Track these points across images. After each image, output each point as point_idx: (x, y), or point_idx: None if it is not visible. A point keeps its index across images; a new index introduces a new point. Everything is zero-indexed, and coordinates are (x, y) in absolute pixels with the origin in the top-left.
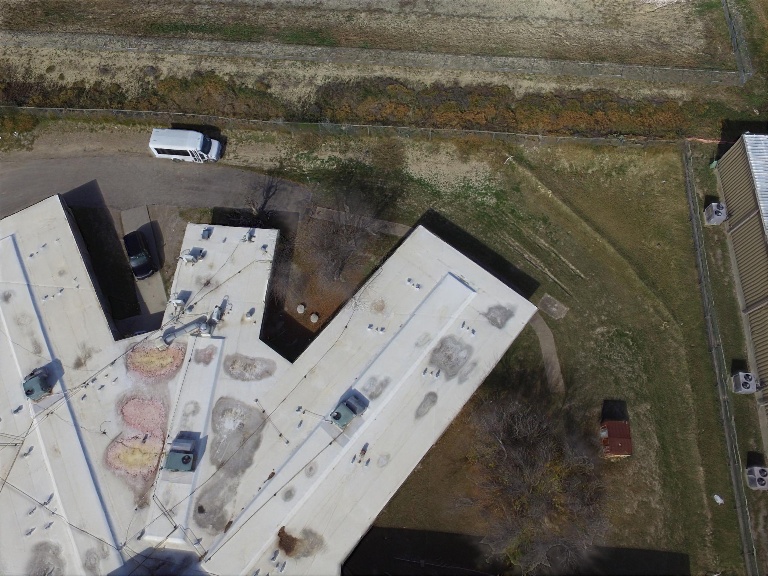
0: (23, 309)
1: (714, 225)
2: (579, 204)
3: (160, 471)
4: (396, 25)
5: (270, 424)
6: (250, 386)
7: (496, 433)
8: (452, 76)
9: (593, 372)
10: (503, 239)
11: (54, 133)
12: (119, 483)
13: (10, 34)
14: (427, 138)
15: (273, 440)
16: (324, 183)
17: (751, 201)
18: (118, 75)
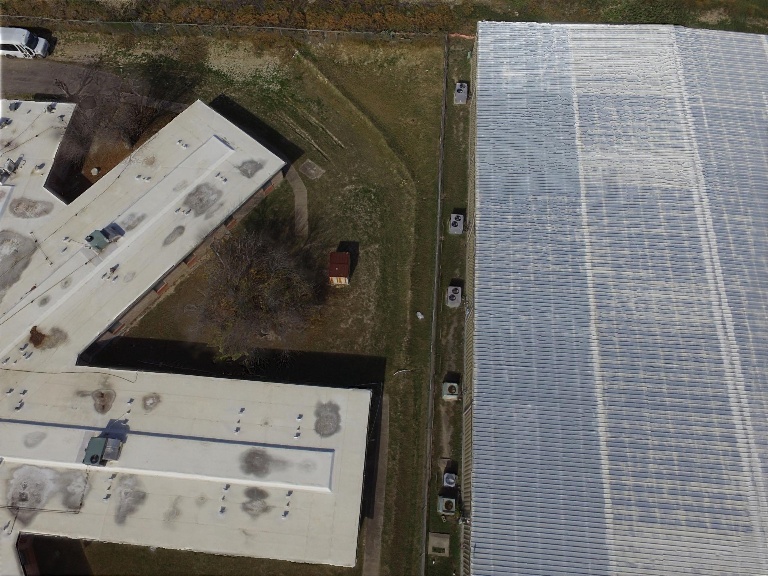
0: None
1: (461, 104)
2: (351, 89)
3: None
4: None
5: (39, 250)
6: (28, 222)
7: (214, 247)
8: None
9: (336, 220)
10: (280, 117)
11: None
12: None
13: None
14: (227, 36)
15: (40, 262)
16: (134, 74)
17: None
18: None
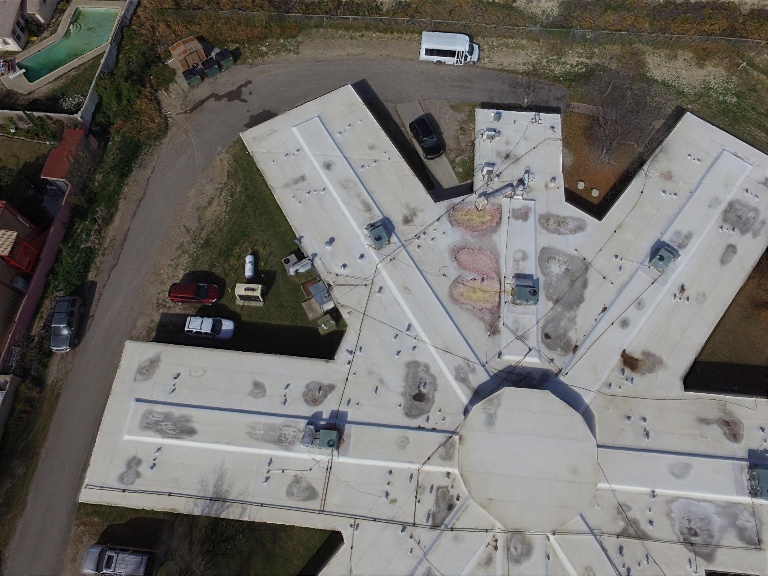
0: (345, 176)
1: None
2: None
3: (505, 305)
4: None
5: (593, 269)
6: (567, 239)
7: None
8: None
9: None
10: (750, 131)
11: (317, 40)
12: (468, 315)
13: None
14: (667, 46)
15: (598, 282)
16: (577, 83)
17: None
18: None
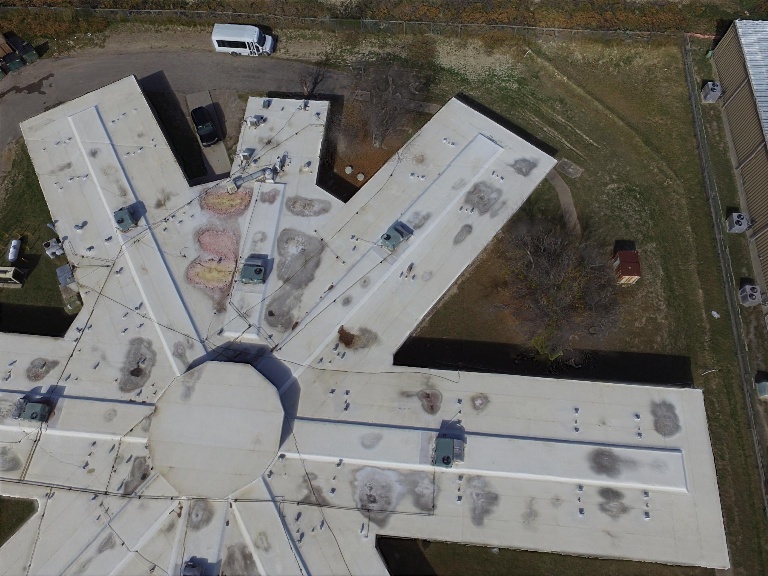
0: (108, 162)
1: (710, 103)
2: (591, 88)
3: (235, 284)
4: None
5: (328, 249)
6: (309, 220)
7: (525, 245)
8: None
9: (605, 219)
10: (525, 116)
11: (123, 34)
12: (199, 294)
13: None
14: (456, 35)
15: (331, 261)
16: None
17: (742, 73)
18: None
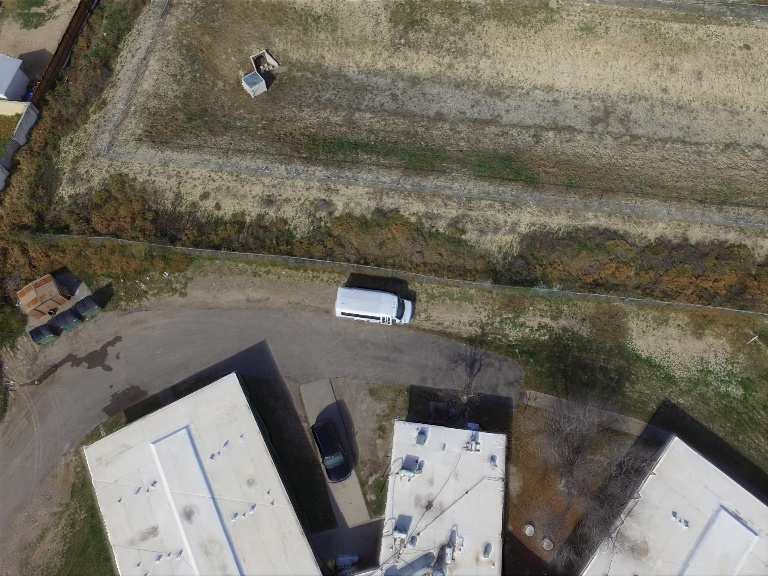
0: (210, 533)
1: None
2: None
3: None
4: (594, 151)
5: None
6: None
7: None
8: (680, 230)
9: None
10: (759, 445)
11: (211, 275)
12: None
13: (154, 148)
14: (656, 308)
15: None
16: (537, 359)
17: None
18: (284, 208)
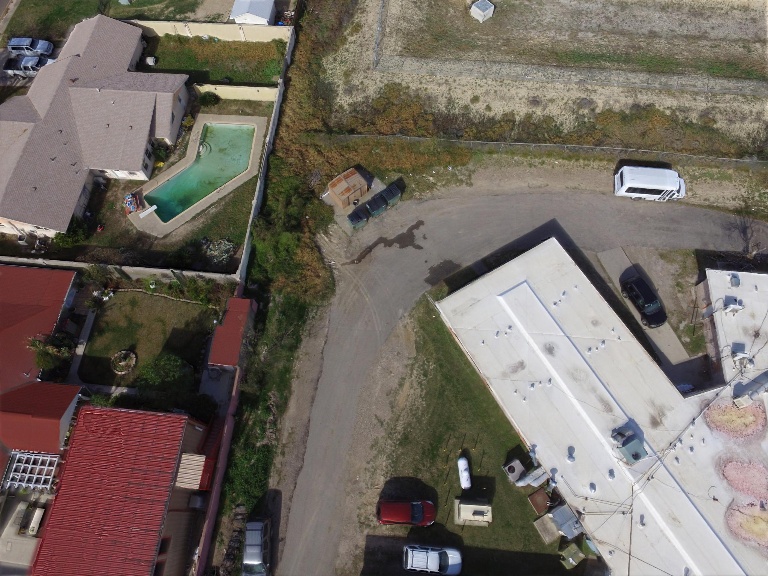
0: (573, 363)
1: None
2: None
3: None
4: None
5: None
6: None
7: None
8: None
9: None
10: None
11: (491, 168)
12: (754, 555)
13: (418, 61)
14: None
15: None
16: None
17: None
18: (549, 107)
